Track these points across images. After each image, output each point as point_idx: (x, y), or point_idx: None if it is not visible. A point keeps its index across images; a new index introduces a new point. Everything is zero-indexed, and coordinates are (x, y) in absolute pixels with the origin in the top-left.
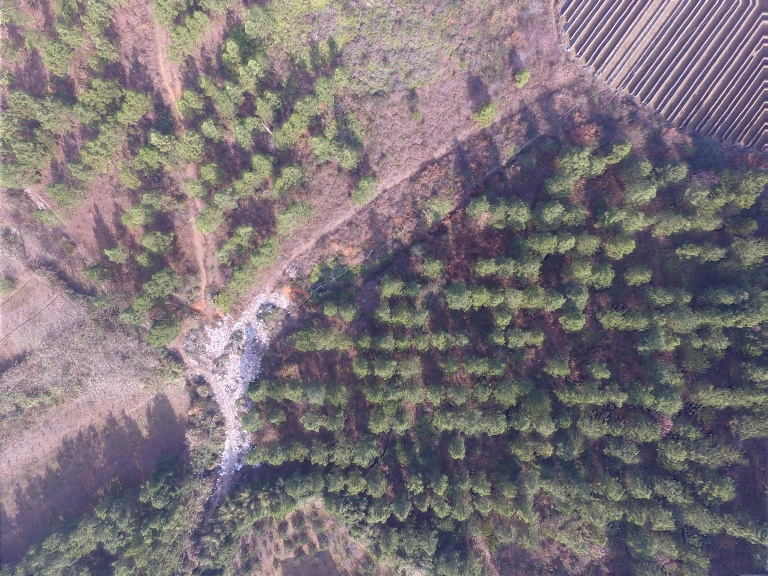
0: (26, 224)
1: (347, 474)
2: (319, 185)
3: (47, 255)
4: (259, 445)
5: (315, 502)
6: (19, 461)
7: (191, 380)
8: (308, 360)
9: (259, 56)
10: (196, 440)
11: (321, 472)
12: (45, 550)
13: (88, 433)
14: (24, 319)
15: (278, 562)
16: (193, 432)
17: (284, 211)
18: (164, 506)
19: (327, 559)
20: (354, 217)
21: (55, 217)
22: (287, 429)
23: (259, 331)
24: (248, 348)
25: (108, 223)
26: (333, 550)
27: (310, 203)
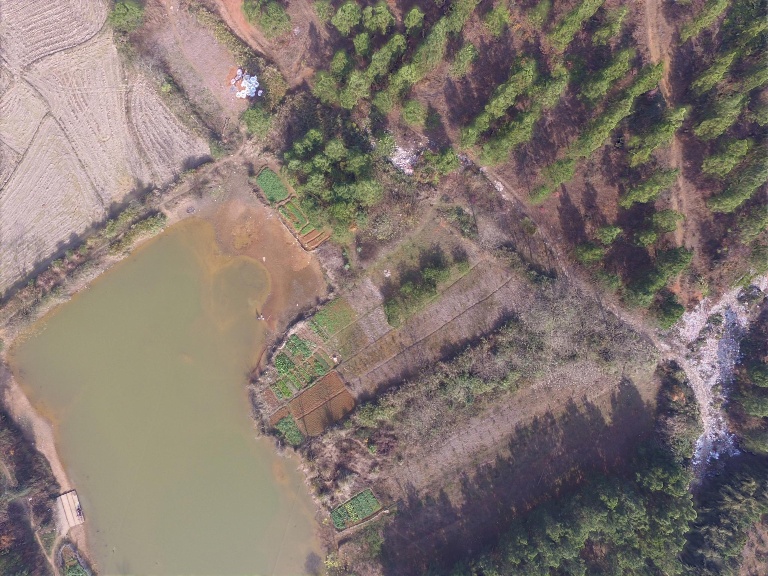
0: (480, 204)
1: None
2: None
3: (502, 236)
4: (767, 432)
5: None
6: (466, 449)
7: (663, 365)
8: None
9: (764, 31)
10: (682, 427)
11: None
12: (547, 540)
13: (545, 420)
14: (474, 302)
15: (761, 554)
16: (678, 419)
17: None
18: None
19: None
20: None
21: (514, 197)
22: None
23: (739, 315)
24: (726, 332)
25: (575, 203)
26: None
27: None
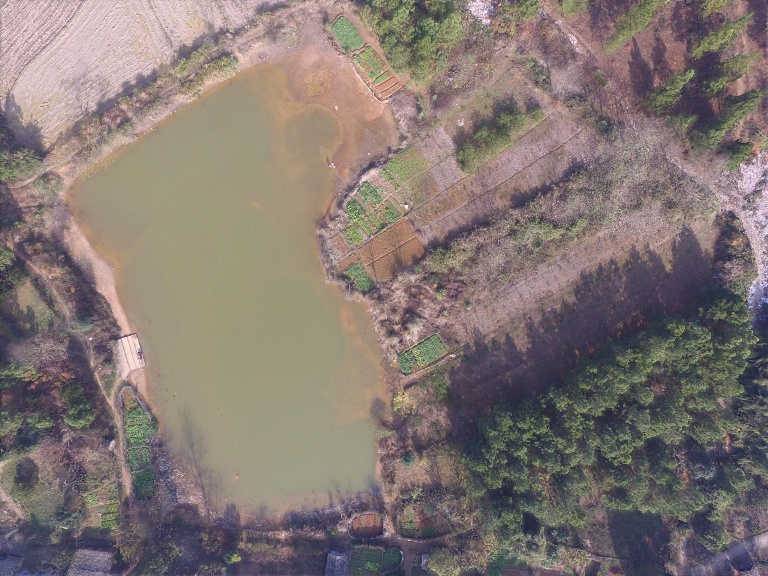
0: (554, 56)
1: None
2: None
3: (575, 88)
4: None
5: None
6: (532, 295)
7: (721, 215)
8: None
9: None
10: (739, 269)
11: None
12: (617, 366)
13: (609, 267)
14: (545, 152)
15: None
16: (736, 262)
17: None
18: None
19: None
20: None
21: (587, 50)
22: None
23: None
24: None
25: (645, 58)
26: None
27: None
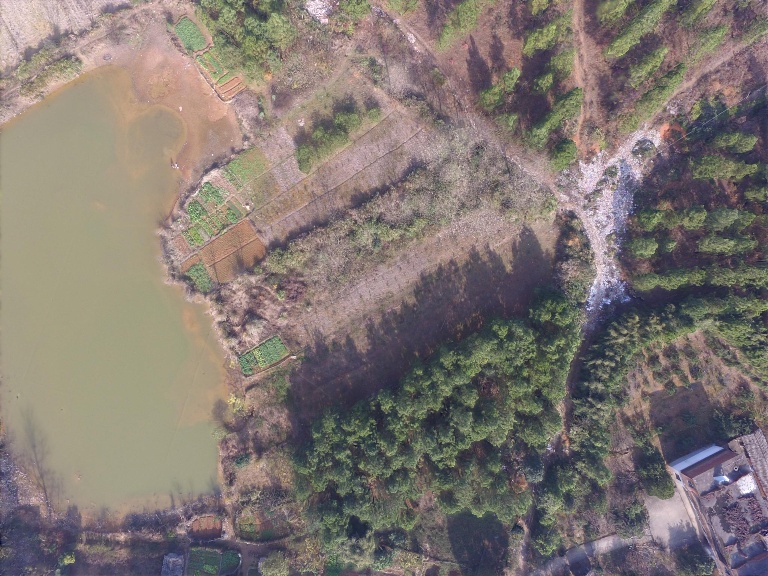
0: (393, 55)
1: (748, 296)
2: (707, 23)
3: (414, 87)
4: (652, 271)
5: (688, 335)
6: (372, 296)
7: (561, 215)
8: (681, 197)
9: None
10: (575, 270)
11: (716, 297)
12: (440, 368)
13: (449, 267)
14: (385, 152)
15: (646, 395)
16: (572, 262)
17: (670, 48)
18: (565, 325)
19: (699, 391)
20: (733, 59)
21: (425, 49)
22: (664, 262)
23: (634, 167)
24: (621, 184)
25: (483, 56)
26: (706, 381)
27: (695, 41)
